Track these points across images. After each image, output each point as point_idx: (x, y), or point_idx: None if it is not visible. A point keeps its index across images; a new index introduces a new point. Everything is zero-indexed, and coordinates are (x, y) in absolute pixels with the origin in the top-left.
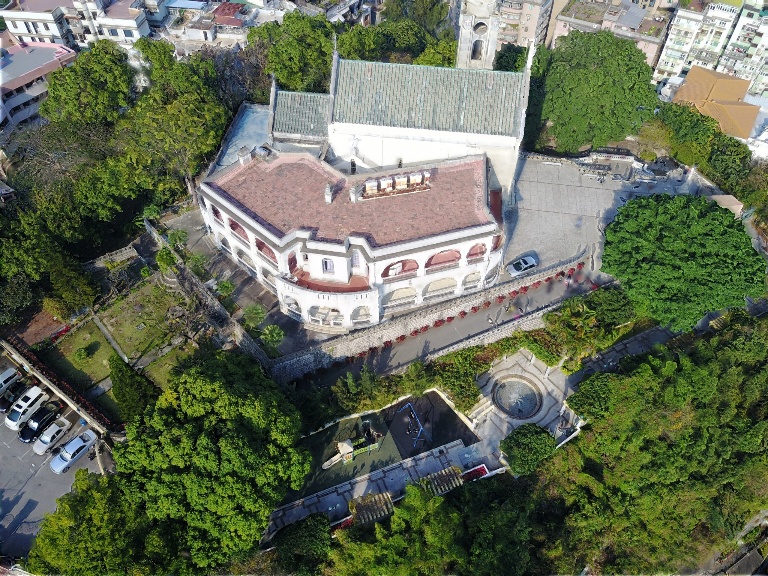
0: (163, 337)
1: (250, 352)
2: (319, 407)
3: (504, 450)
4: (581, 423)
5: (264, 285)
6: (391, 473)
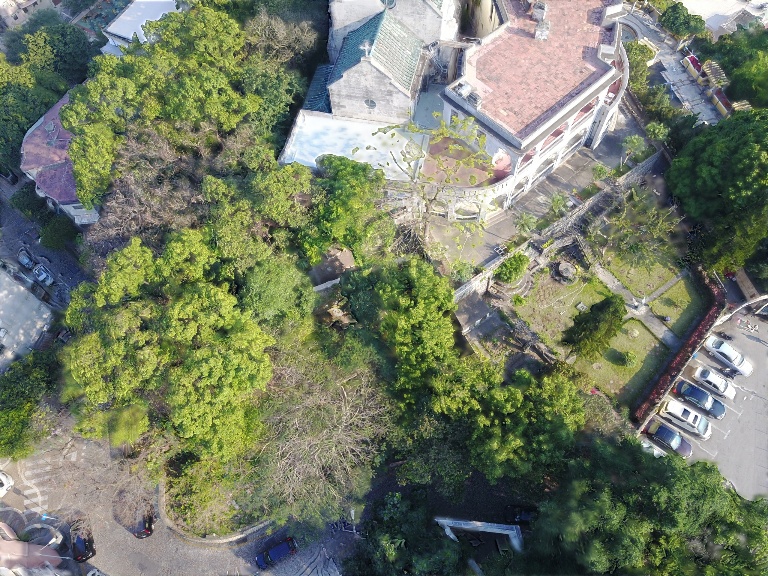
0: (669, 221)
1: (631, 184)
2: (693, 123)
3: (688, 33)
4: (640, 2)
5: (560, 164)
6: (698, 116)
